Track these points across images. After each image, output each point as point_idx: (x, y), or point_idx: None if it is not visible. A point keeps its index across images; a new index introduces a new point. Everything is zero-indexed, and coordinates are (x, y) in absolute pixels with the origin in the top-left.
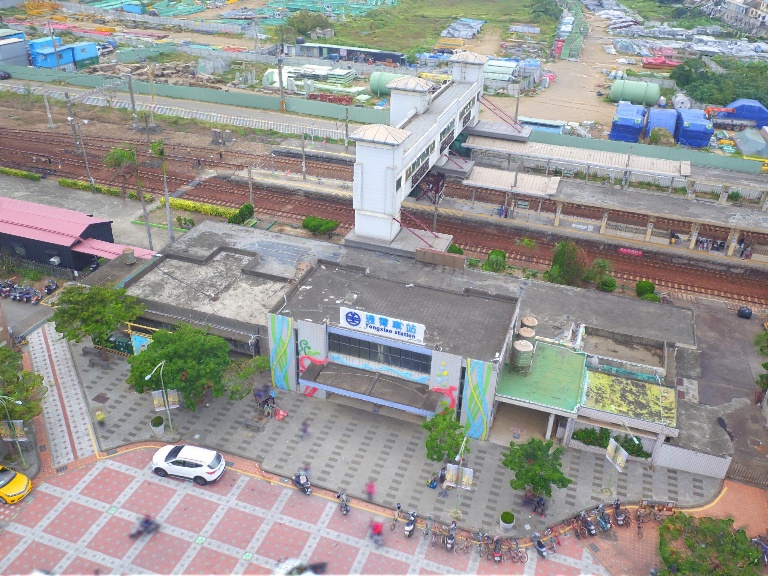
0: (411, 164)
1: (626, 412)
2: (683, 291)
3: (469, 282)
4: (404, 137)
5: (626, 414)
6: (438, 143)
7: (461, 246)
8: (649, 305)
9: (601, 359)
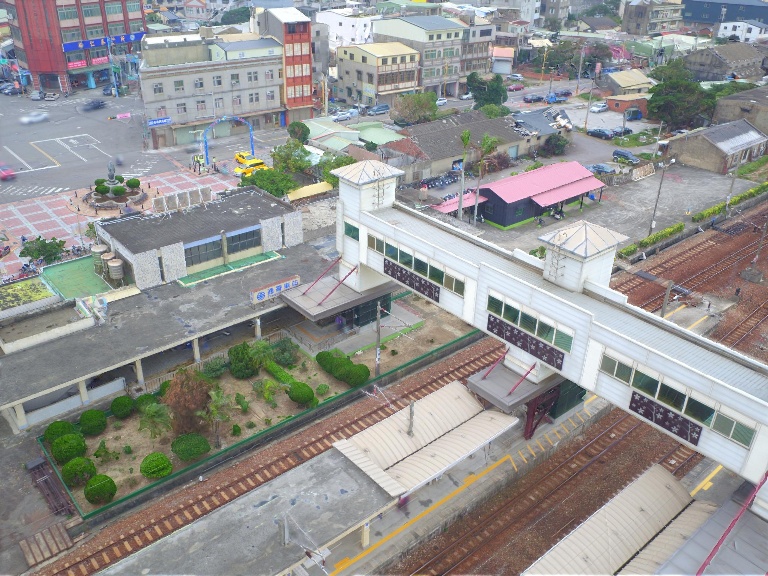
0: (384, 240)
1: (7, 289)
2: (55, 570)
3: (234, 304)
4: (344, 175)
5: (6, 288)
6: (482, 304)
7: (385, 414)
8: (49, 384)
9: (53, 307)
